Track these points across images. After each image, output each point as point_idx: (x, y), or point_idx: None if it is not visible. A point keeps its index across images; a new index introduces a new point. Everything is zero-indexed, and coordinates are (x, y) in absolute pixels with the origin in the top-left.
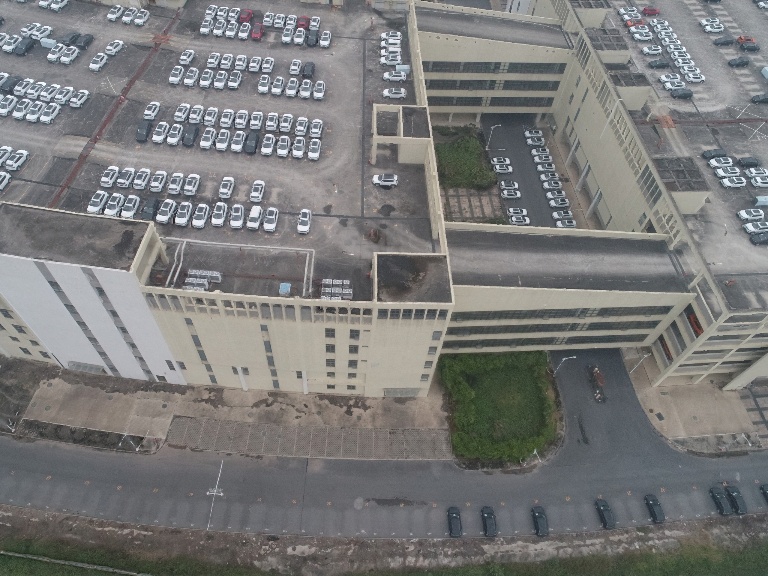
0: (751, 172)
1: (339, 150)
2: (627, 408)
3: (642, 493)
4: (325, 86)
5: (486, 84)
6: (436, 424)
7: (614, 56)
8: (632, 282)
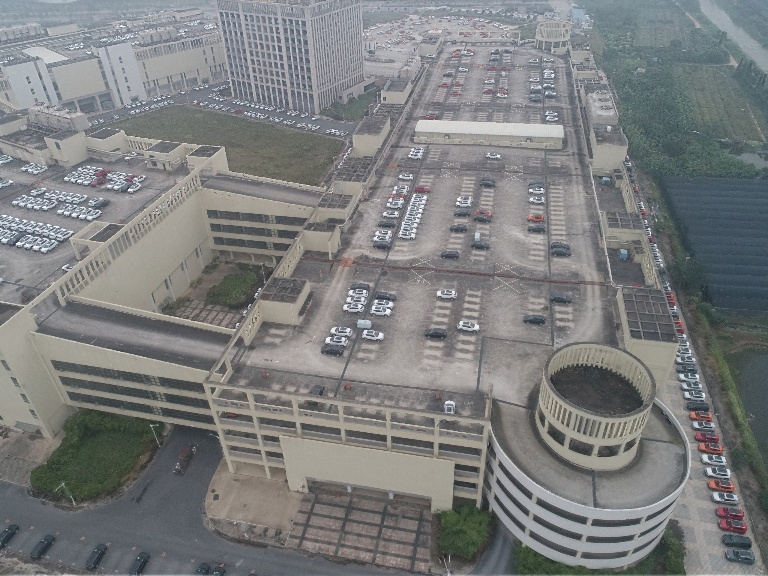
0: (374, 302)
1: (67, 249)
2: (196, 484)
3: (142, 550)
4: (104, 214)
5: (265, 232)
6: (41, 459)
7: (334, 213)
8: (184, 359)
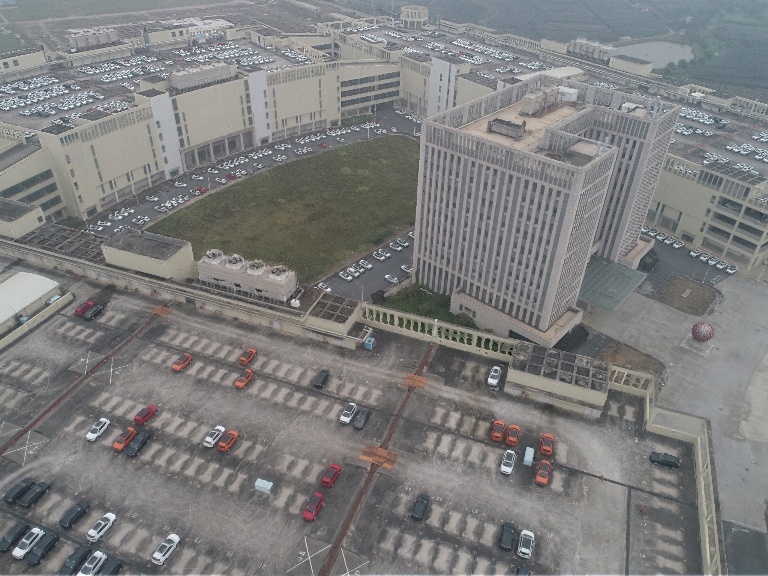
0: None
1: None
2: None
3: None
4: None
5: None
6: None
7: None
8: None
